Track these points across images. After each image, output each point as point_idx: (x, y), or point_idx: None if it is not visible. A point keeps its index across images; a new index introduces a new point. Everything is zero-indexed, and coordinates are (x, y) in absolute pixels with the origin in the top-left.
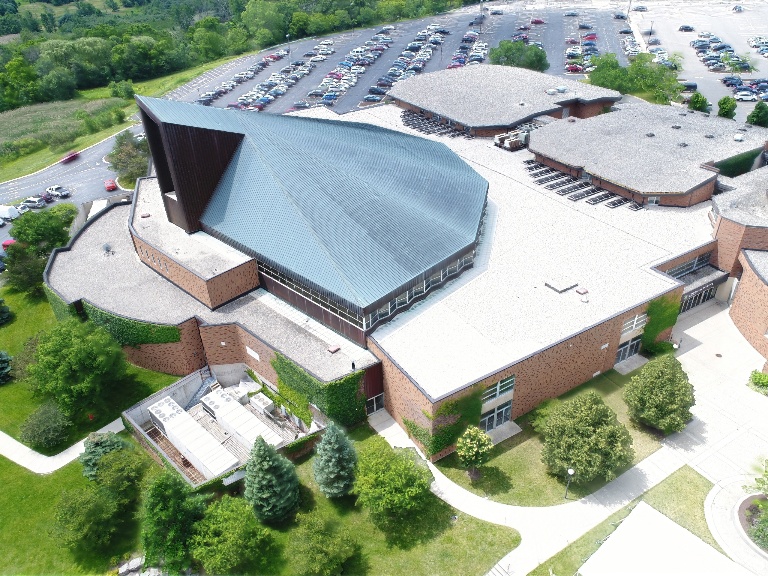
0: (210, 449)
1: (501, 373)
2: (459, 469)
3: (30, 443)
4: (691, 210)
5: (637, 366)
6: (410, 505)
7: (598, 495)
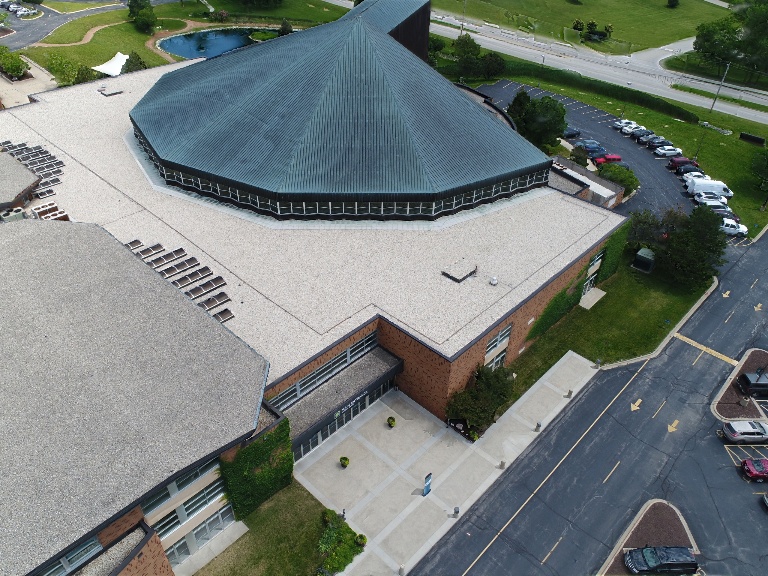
0: None
1: None
2: None
3: None
4: None
5: None
6: None
7: None
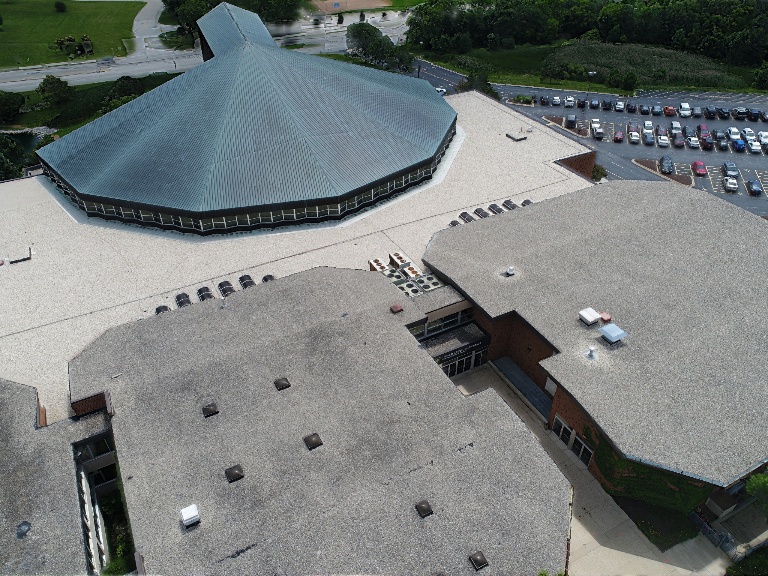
0: None
1: None
2: None
3: None
4: None
5: None
6: None
7: None
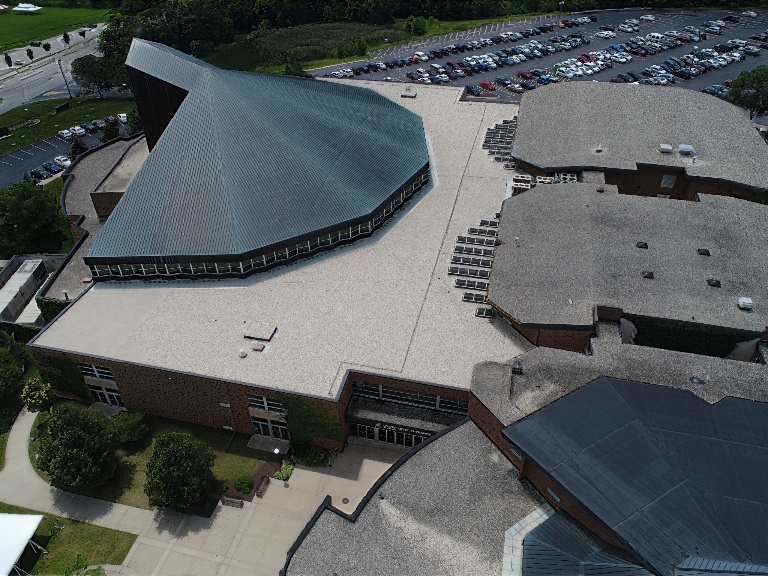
0: (2, 301)
1: (90, 359)
2: (52, 410)
3: None
4: None
5: (269, 449)
6: None
7: (64, 495)
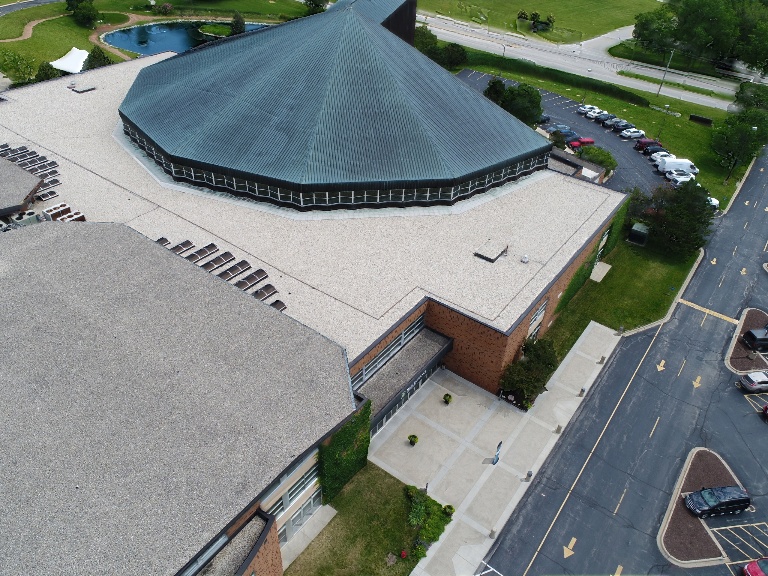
0: None
1: None
2: None
3: None
4: None
5: None
6: None
7: None
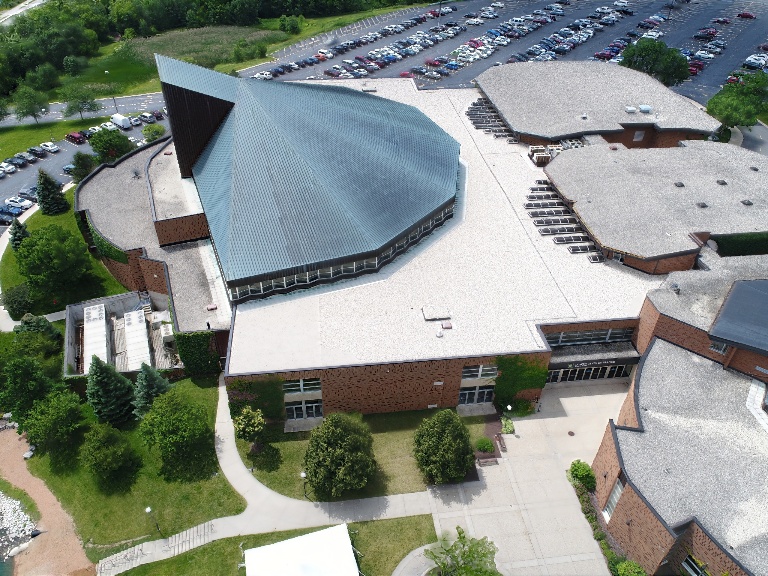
0: (97, 353)
1: (301, 373)
2: None
3: (4, 307)
4: (653, 279)
5: (480, 413)
6: (170, 448)
7: (332, 505)
